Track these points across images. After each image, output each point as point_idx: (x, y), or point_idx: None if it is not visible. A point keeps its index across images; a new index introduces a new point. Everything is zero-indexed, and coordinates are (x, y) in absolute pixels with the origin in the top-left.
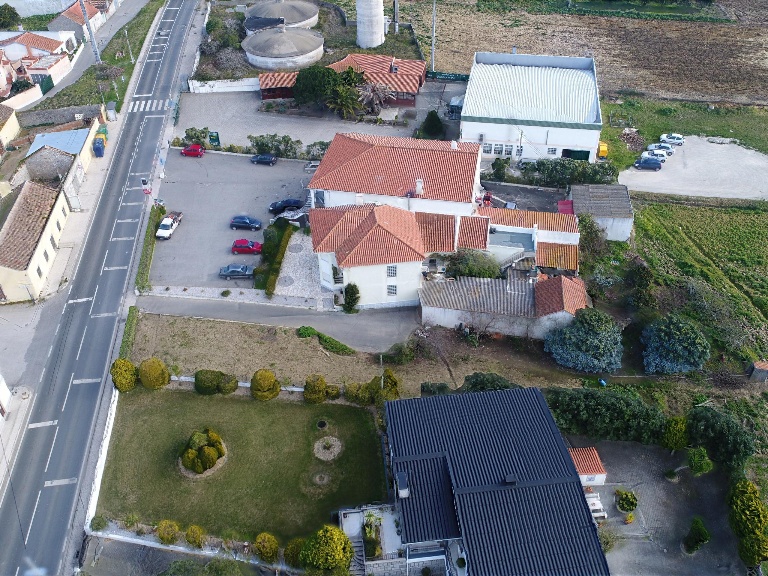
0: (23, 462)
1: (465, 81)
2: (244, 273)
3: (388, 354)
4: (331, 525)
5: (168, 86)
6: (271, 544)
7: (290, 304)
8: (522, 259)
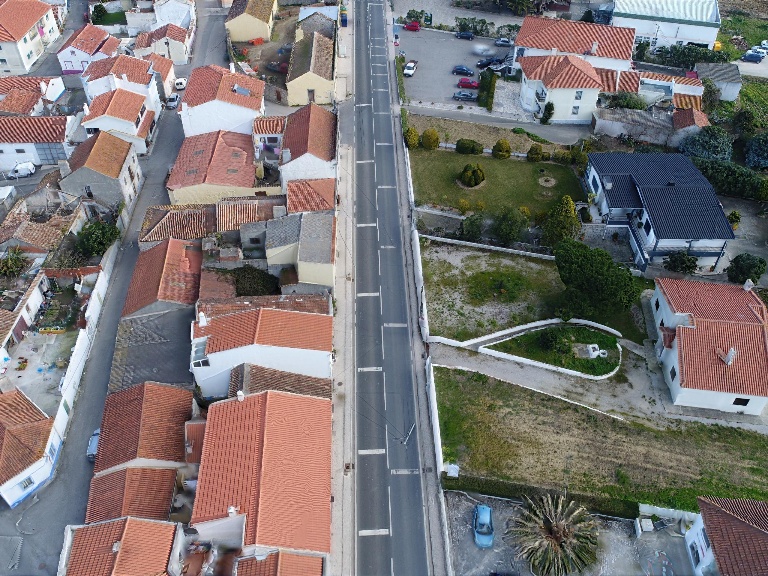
0: (360, 177)
1: None
2: (471, 97)
3: (575, 145)
4: None
5: None
6: (528, 211)
7: (504, 116)
8: (663, 101)
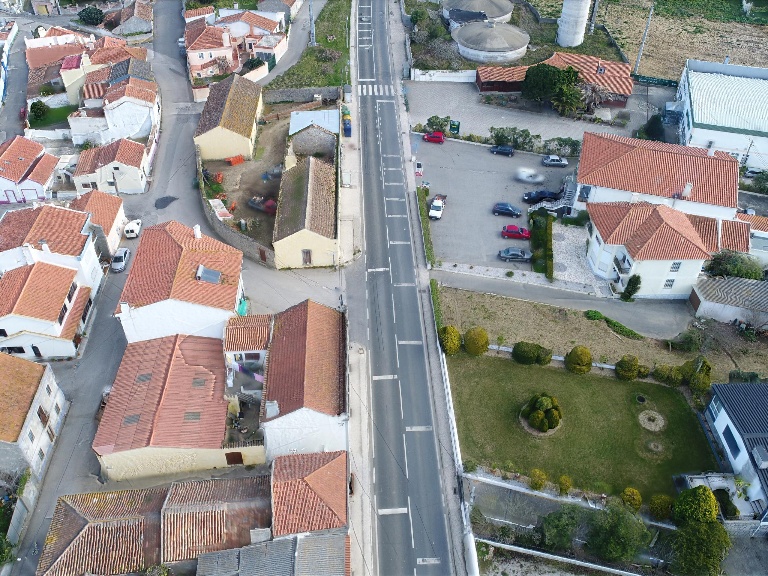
0: (380, 408)
1: (666, 86)
2: (523, 257)
3: (675, 342)
4: (676, 487)
5: (388, 72)
6: (639, 497)
7: (571, 288)
8: None
